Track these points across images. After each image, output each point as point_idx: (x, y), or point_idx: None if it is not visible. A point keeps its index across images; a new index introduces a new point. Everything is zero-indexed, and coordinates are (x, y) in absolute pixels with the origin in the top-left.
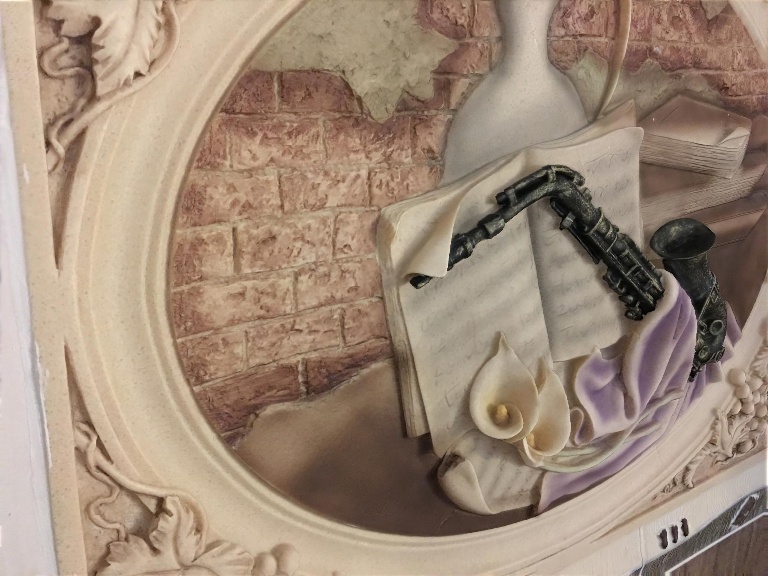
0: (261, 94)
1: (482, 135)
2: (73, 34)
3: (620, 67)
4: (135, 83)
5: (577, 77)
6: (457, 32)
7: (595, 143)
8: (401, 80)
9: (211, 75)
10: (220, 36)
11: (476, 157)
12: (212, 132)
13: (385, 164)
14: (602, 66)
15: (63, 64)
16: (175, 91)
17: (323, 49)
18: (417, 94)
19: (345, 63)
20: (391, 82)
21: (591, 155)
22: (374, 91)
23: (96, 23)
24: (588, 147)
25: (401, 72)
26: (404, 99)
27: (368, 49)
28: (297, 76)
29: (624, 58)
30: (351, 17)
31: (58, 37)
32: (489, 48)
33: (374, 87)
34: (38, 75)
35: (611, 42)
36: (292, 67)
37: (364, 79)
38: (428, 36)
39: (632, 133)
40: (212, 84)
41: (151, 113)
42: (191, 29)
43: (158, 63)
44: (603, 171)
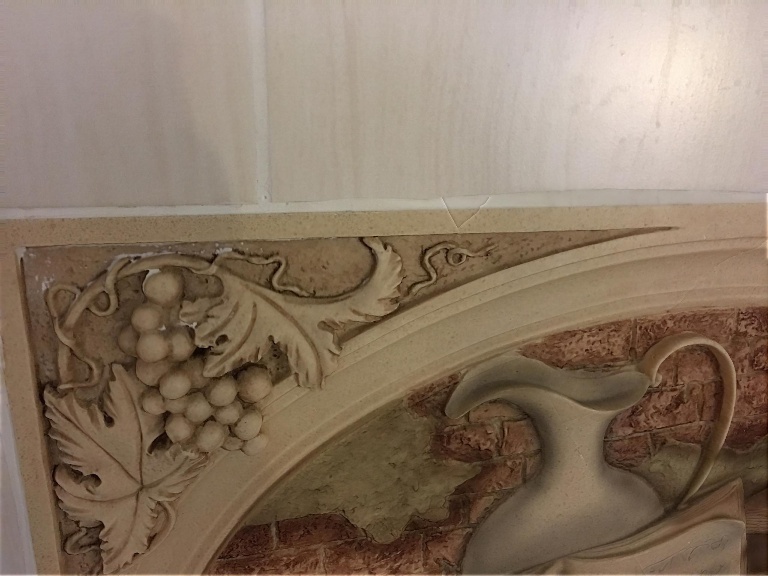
0: (258, 540)
1: (505, 549)
2: (88, 526)
3: (715, 457)
4: (136, 559)
5: (649, 471)
6: (480, 456)
7: (662, 547)
8: (409, 509)
9: (212, 528)
10: (221, 497)
11: (498, 568)
12: (210, 574)
13: (392, 575)
14: (691, 453)
15: (84, 542)
16: (180, 543)
17: (320, 498)
18: (428, 518)
19: (345, 505)
20: (397, 512)
21: (656, 557)
22: (378, 521)
23: (102, 524)
24: (650, 553)
25: (409, 502)
26: (414, 521)
27: (371, 489)
28: (294, 521)
29: (729, 437)
30: (351, 468)
31: (78, 527)
32: (524, 461)
33: (378, 518)
34: (60, 562)
35: (708, 424)
36: (287, 518)
37: (366, 514)
38: (442, 468)
39: (728, 523)
40: (213, 535)
41: (159, 562)
42: (192, 499)
43: (157, 539)
44: (679, 565)
